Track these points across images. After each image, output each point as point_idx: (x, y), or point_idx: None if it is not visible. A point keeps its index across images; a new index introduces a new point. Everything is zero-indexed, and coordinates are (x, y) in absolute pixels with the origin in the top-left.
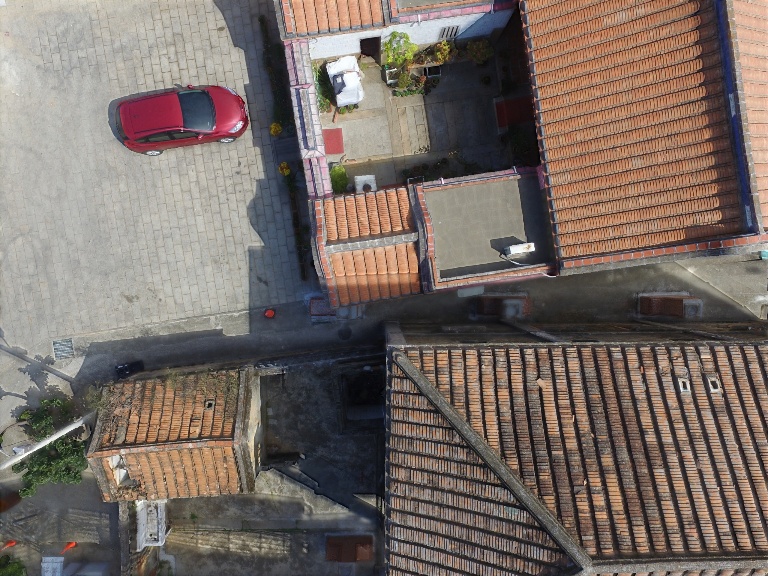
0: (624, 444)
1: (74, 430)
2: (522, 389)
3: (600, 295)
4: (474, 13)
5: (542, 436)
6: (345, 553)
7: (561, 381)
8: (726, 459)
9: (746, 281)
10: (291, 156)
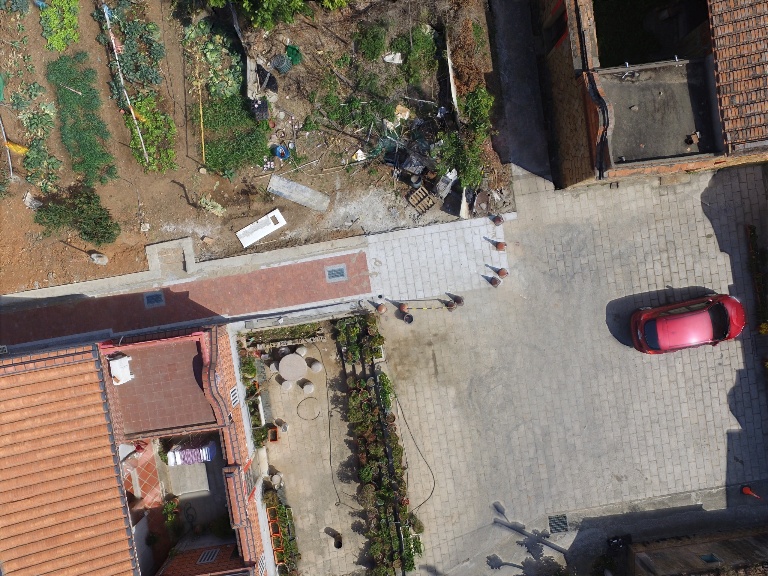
0: None
1: None
2: None
3: None
4: None
5: None
6: None
7: None
8: None
9: None
10: None
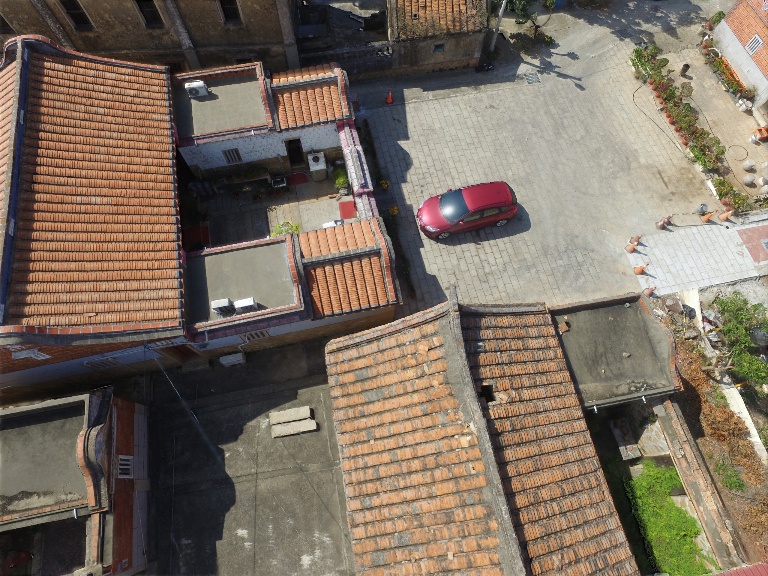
0: None
1: (516, 37)
2: None
3: None
4: None
5: None
6: None
7: None
8: None
9: None
10: (381, 198)
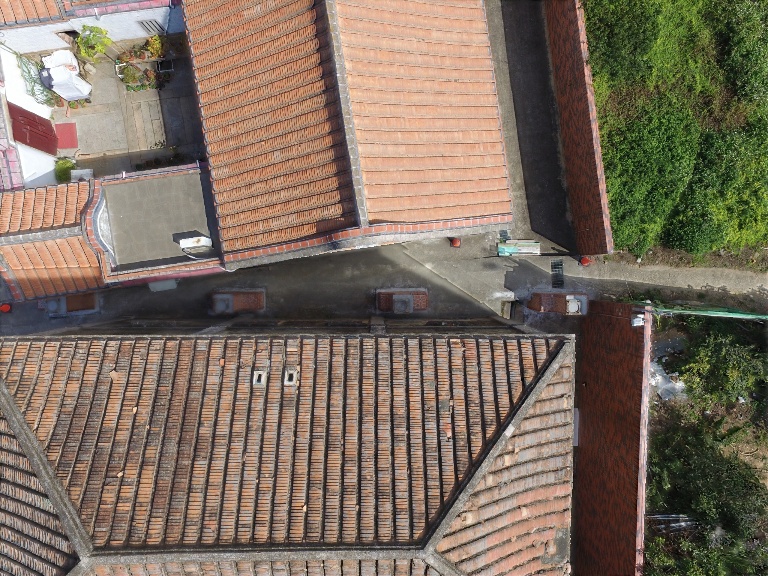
0: (174, 436)
1: None
2: (93, 381)
3: (338, 291)
4: (155, 7)
5: (95, 428)
6: None
7: (135, 373)
8: (276, 451)
9: (483, 278)
10: None
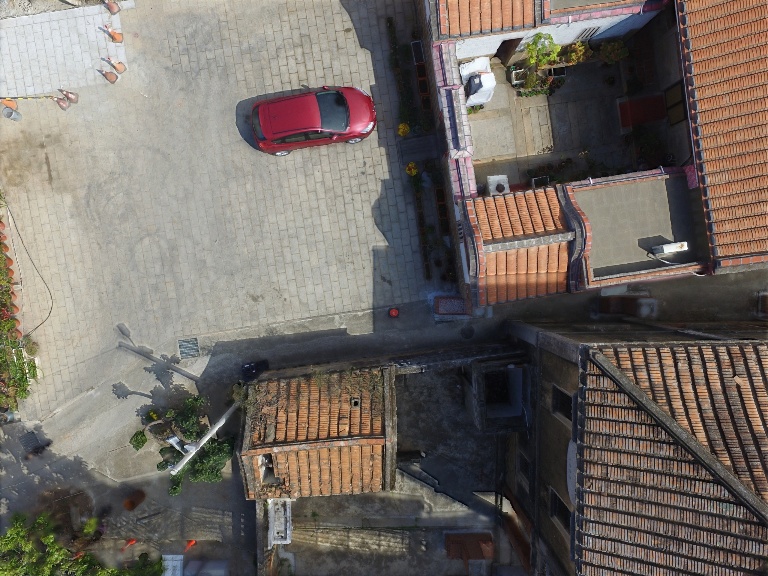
0: None
1: None
2: (720, 386)
3: (721, 294)
4: (623, 14)
5: (748, 433)
6: (472, 550)
7: (757, 378)
8: None
9: None
10: (416, 156)
